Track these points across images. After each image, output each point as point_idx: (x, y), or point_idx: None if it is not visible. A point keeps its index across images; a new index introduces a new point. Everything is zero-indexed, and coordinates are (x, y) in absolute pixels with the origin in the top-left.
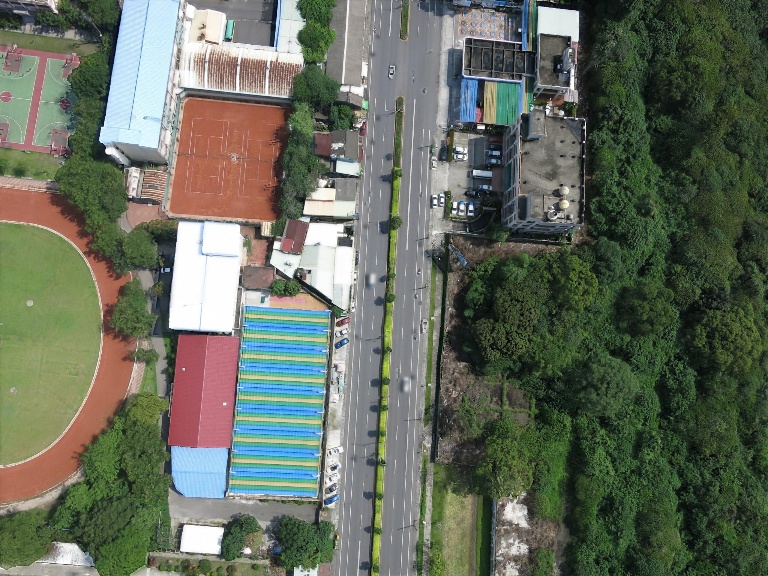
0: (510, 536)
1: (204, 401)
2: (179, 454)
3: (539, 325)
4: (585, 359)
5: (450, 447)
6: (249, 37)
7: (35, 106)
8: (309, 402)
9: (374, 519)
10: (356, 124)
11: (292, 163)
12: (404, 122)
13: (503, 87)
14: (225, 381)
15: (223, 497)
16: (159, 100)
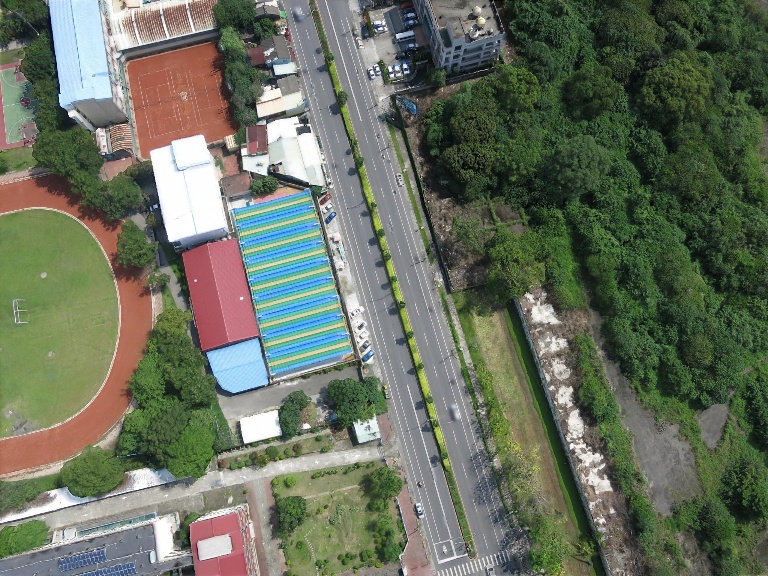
0: (545, 336)
1: (222, 300)
2: (215, 355)
3: (498, 133)
4: (553, 153)
5: (461, 275)
6: None
7: (0, 112)
8: (317, 273)
9: (413, 360)
10: (280, 32)
11: (233, 76)
12: (322, 19)
13: None
14: (236, 279)
15: (268, 385)
16: (101, 57)
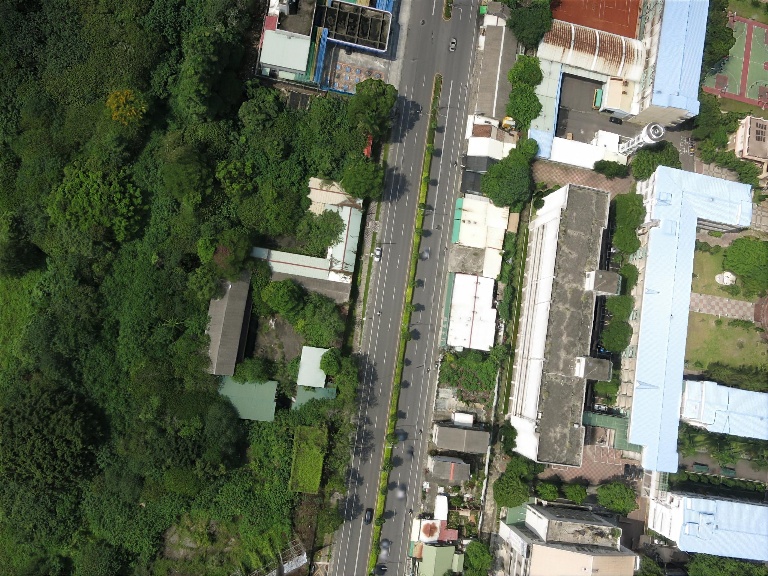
0: None
1: None
2: None
3: None
4: None
5: None
6: (580, 95)
7: (747, 56)
8: None
9: None
10: None
11: None
12: None
13: (350, 0)
14: None
15: None
16: (670, 2)
